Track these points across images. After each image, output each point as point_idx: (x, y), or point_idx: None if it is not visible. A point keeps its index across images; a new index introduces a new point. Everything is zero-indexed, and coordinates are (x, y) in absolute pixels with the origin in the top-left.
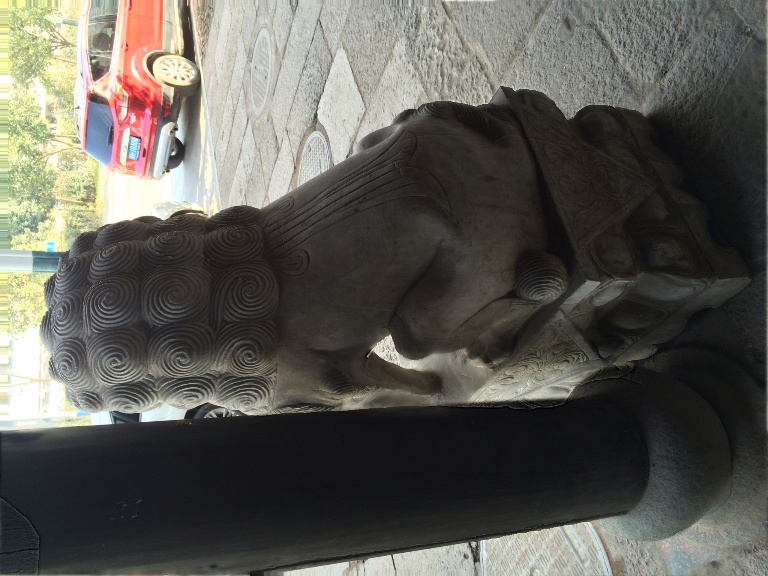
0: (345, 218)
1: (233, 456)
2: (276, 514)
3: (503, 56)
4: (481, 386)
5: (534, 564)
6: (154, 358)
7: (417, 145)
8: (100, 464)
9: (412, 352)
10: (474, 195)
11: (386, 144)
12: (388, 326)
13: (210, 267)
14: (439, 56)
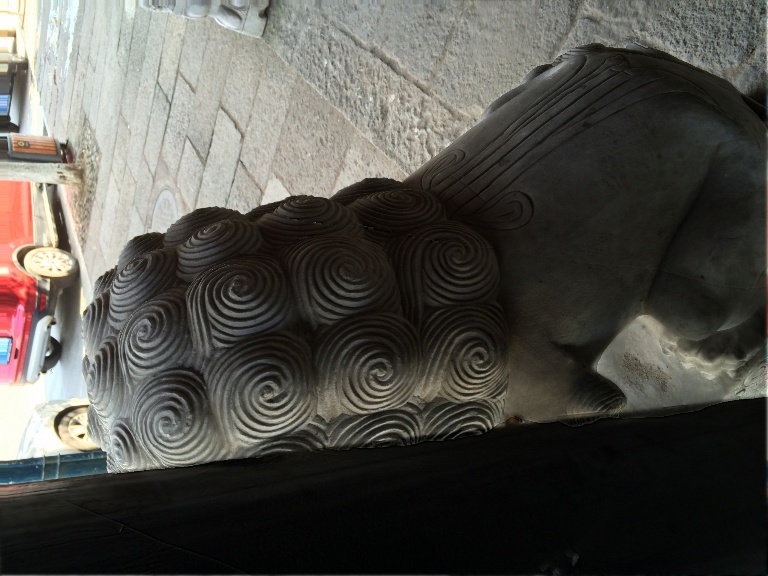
0: (572, 137)
1: (641, 462)
2: (765, 566)
3: None
4: None
5: None
6: (331, 378)
7: (622, 54)
8: (456, 489)
9: (710, 318)
10: (728, 94)
11: (574, 63)
12: (647, 297)
13: (377, 238)
14: (422, 134)
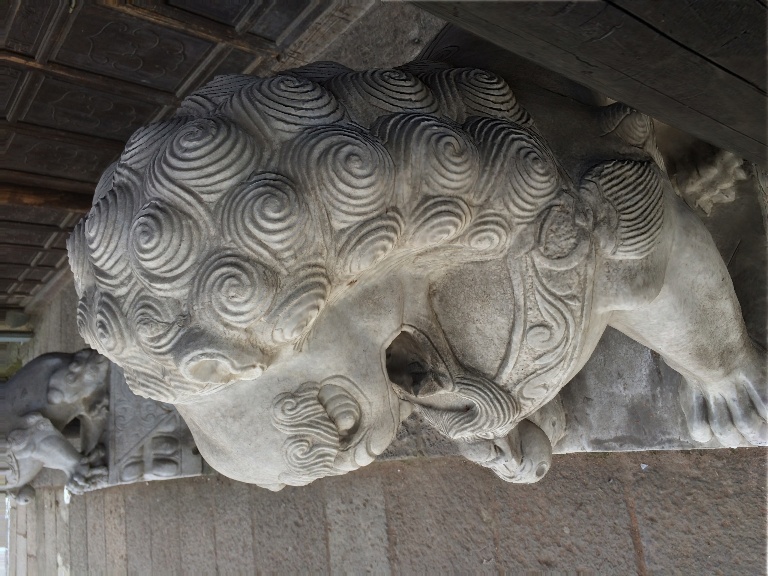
0: None
1: None
2: None
3: None
4: (760, 215)
5: None
6: (348, 85)
7: None
8: None
9: None
10: None
11: None
12: None
13: None
14: None
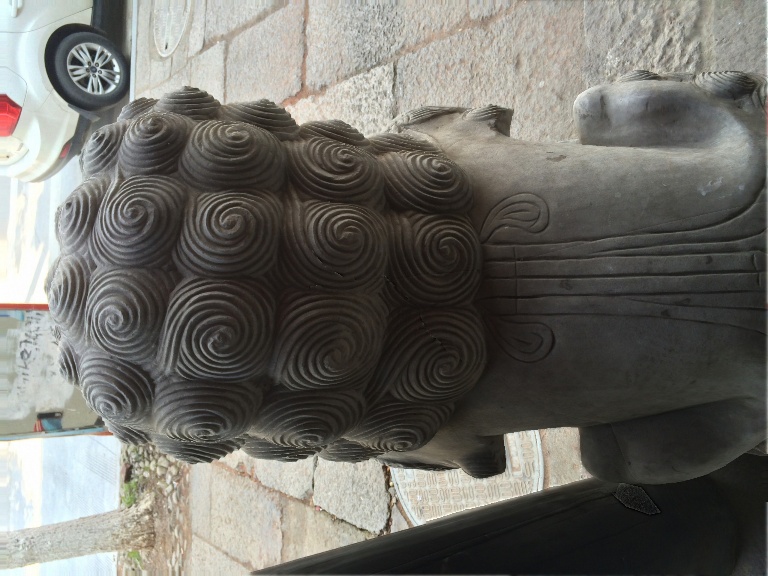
0: (642, 317)
1: None
2: None
3: None
4: None
5: None
6: (267, 430)
7: None
8: None
9: None
10: None
11: (741, 194)
12: (585, 427)
13: (391, 298)
14: None
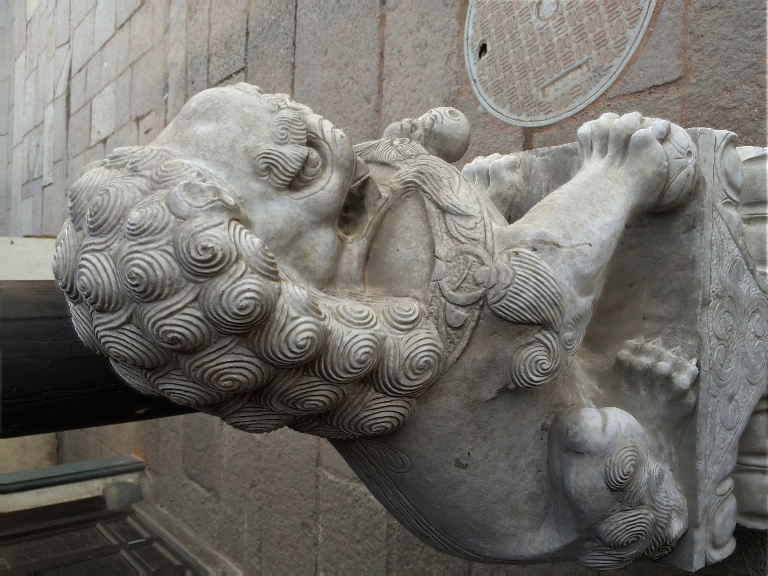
0: None
1: None
2: None
3: None
4: None
5: (561, 4)
6: None
7: None
8: None
9: None
10: None
11: (481, 554)
12: None
13: None
14: None
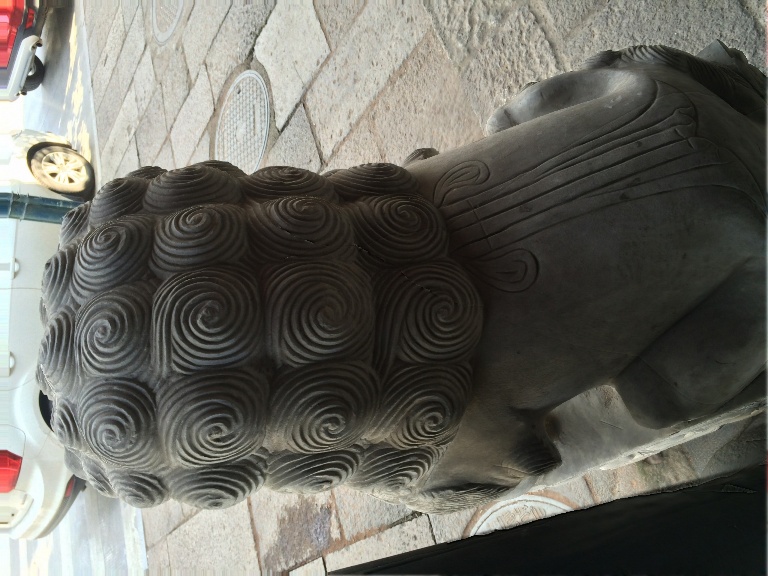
0: (605, 207)
1: None
2: None
3: (574, 9)
4: (644, 443)
5: None
6: (283, 423)
7: (696, 105)
8: None
9: (667, 421)
10: None
11: (641, 97)
12: (618, 375)
13: (368, 265)
14: None
